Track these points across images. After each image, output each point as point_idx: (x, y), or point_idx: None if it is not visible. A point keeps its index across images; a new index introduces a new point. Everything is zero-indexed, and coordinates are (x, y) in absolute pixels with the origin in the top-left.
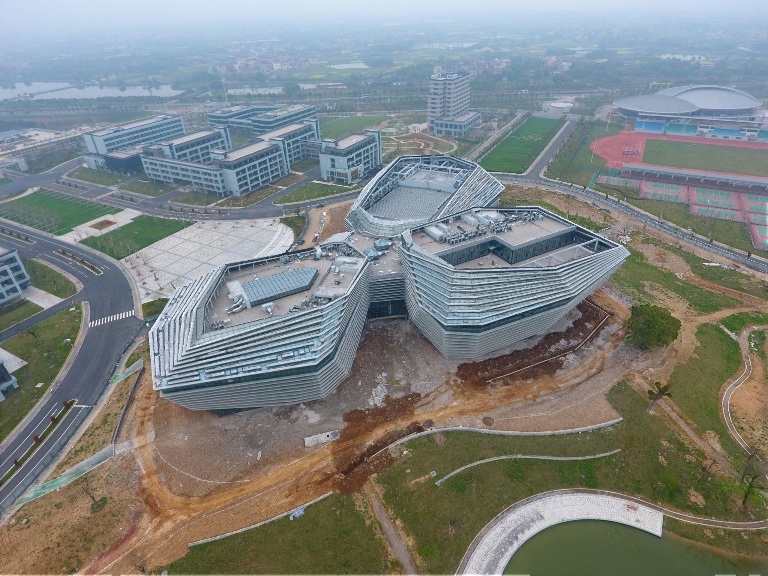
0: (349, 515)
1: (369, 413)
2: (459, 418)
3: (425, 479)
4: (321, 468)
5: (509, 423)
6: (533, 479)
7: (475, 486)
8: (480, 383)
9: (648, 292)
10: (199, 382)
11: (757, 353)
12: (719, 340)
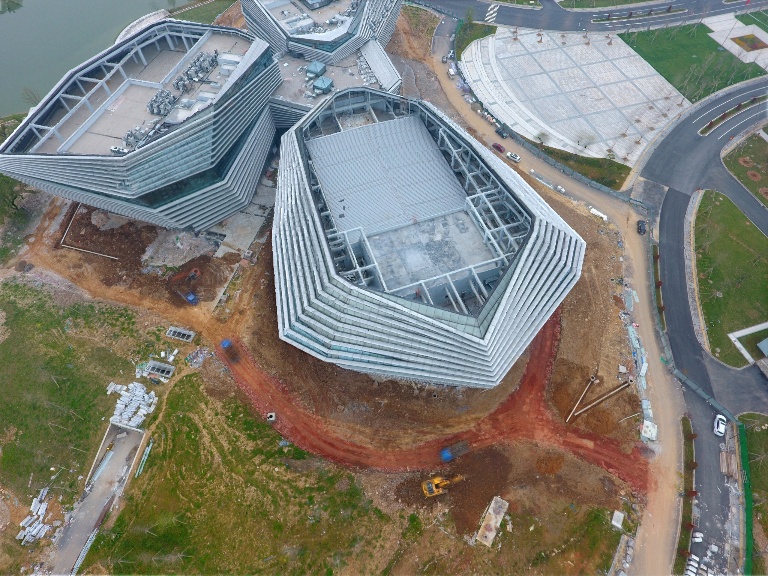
0: None
1: None
2: None
3: None
4: None
5: None
6: None
7: None
8: None
9: (1, 310)
10: None
11: None
12: None
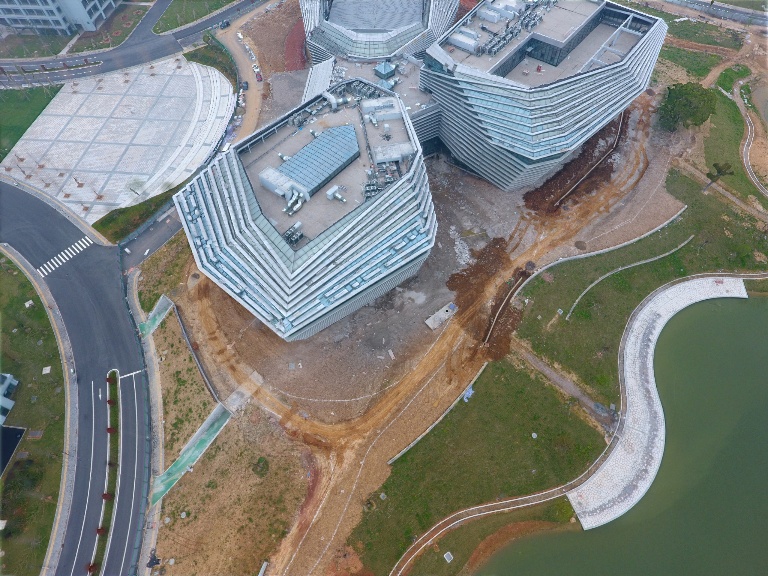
0: (514, 377)
1: (468, 274)
2: (554, 251)
3: (556, 319)
4: (461, 344)
5: (601, 241)
6: (638, 285)
7: (597, 309)
8: (549, 208)
9: None
10: (327, 310)
11: (752, 109)
12: (723, 104)
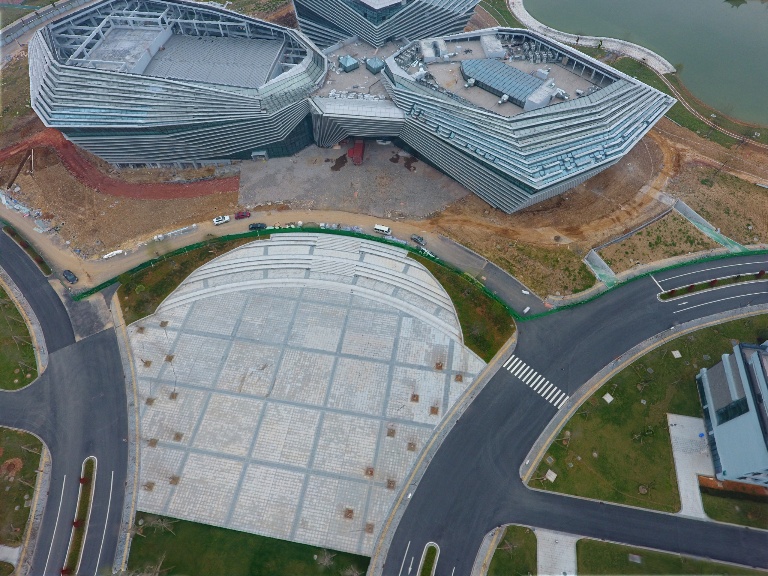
0: None
1: None
2: None
3: None
4: None
5: None
6: None
7: None
8: None
9: None
10: None
11: None
12: None
